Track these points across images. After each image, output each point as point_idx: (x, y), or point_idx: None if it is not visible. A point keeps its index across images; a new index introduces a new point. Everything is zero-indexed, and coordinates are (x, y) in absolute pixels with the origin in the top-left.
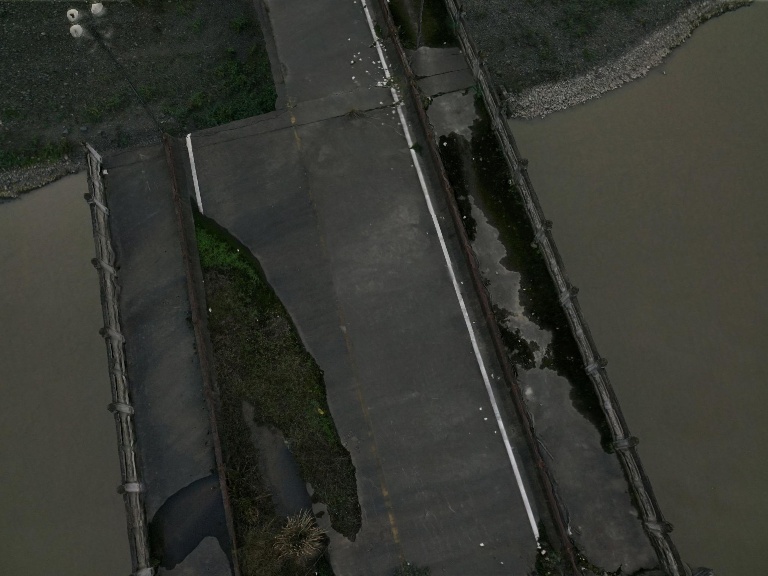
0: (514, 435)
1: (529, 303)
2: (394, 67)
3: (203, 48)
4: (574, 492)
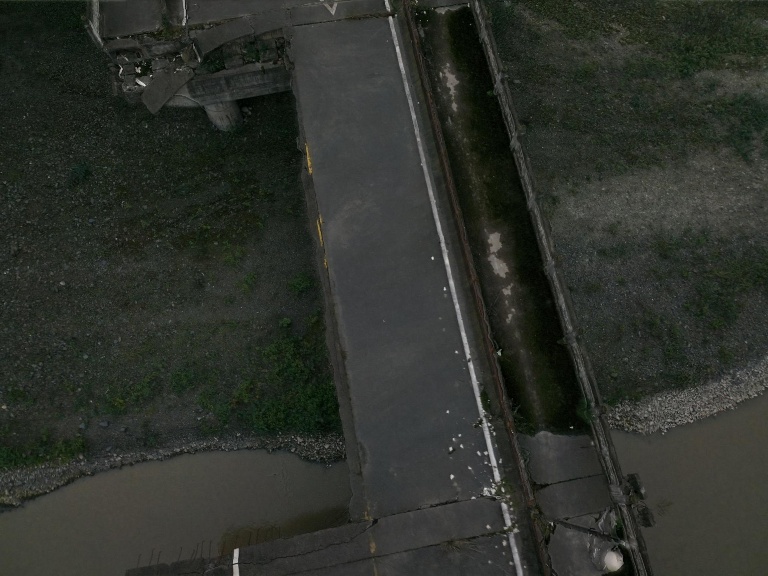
0: None
1: None
2: (506, 466)
3: (253, 314)
4: None
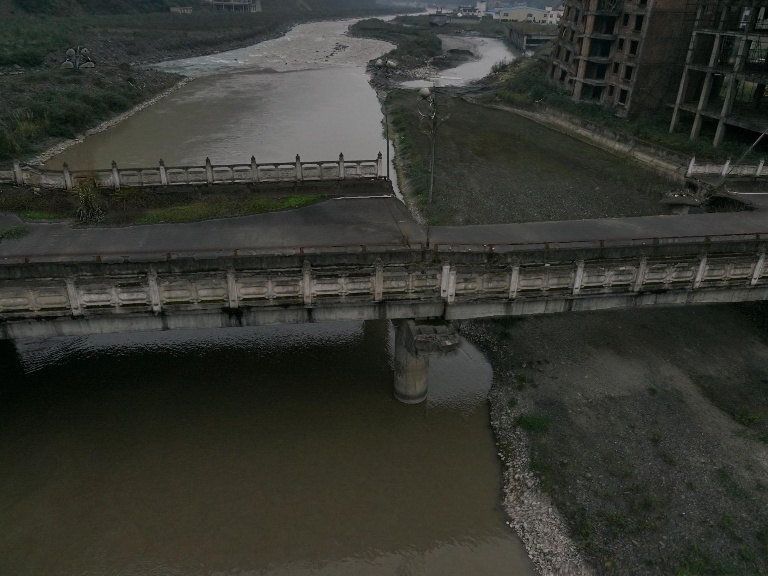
0: None
1: None
2: None
3: None
4: None
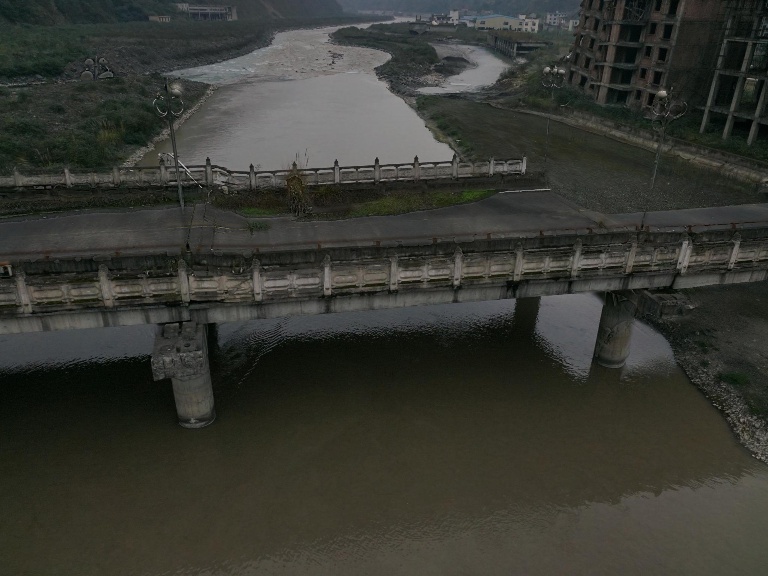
0: None
1: None
2: None
3: None
4: None
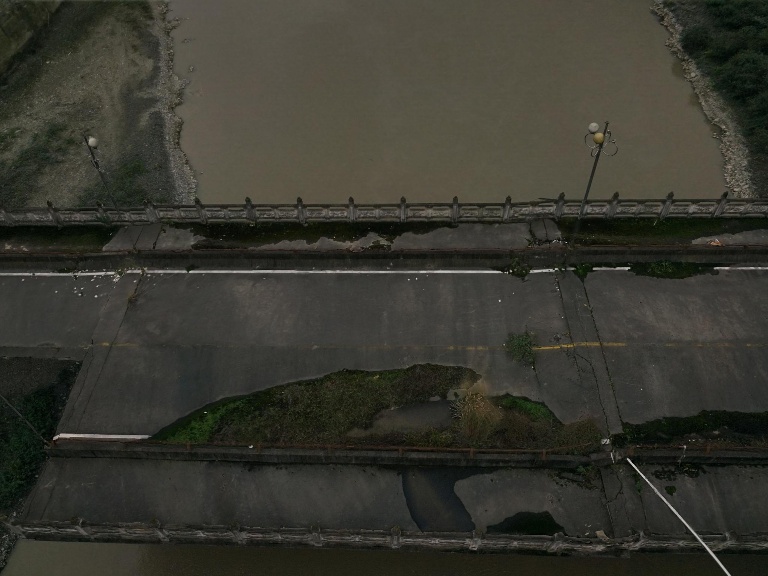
0: (432, 266)
1: (345, 238)
2: (108, 267)
3: None
4: (477, 247)
